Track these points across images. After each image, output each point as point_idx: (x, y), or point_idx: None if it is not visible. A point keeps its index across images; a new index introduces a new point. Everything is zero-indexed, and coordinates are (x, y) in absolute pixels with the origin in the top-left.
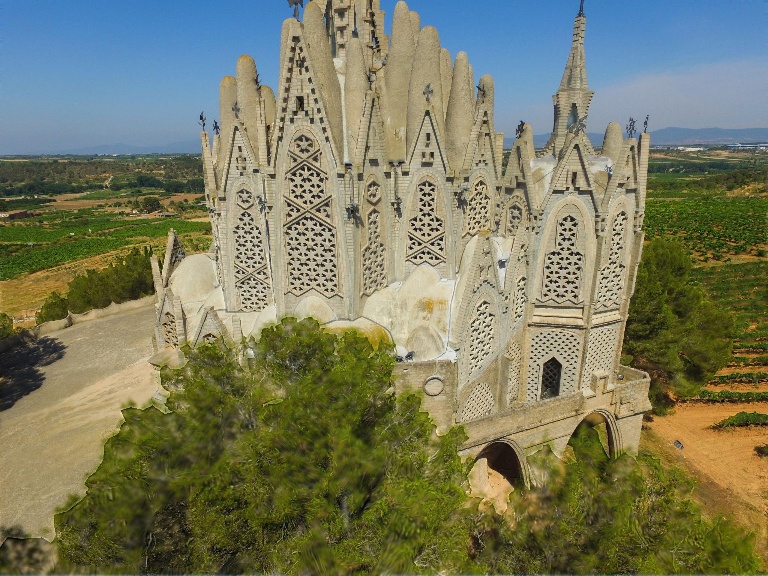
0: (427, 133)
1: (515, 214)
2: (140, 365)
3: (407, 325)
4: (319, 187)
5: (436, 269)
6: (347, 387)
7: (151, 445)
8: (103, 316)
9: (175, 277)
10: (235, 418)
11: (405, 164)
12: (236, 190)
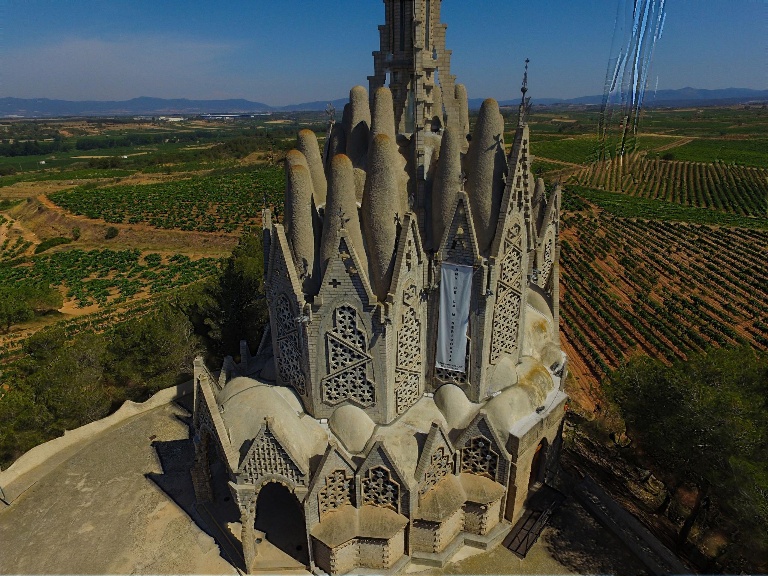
0: None
1: None
2: None
3: (535, 347)
4: (516, 264)
5: None
6: None
7: None
8: None
9: (282, 430)
10: None
11: None
12: (403, 288)
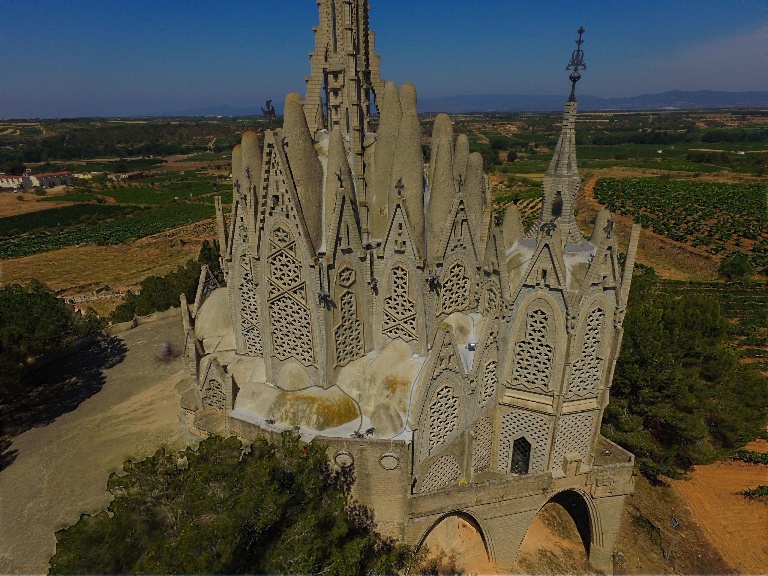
0: (399, 223)
1: (491, 297)
2: (179, 377)
3: (374, 399)
4: (295, 273)
5: (409, 345)
6: (216, 539)
7: (63, 573)
8: (163, 318)
9: (201, 312)
10: (161, 523)
11: (379, 249)
12: (240, 254)
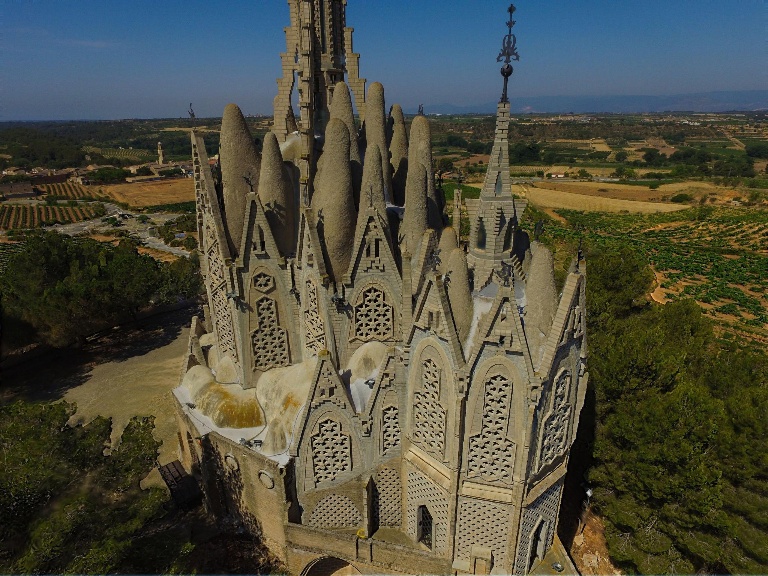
0: None
1: None
2: None
3: None
4: None
5: None
6: None
7: None
8: None
9: None
10: None
11: (296, 259)
12: None
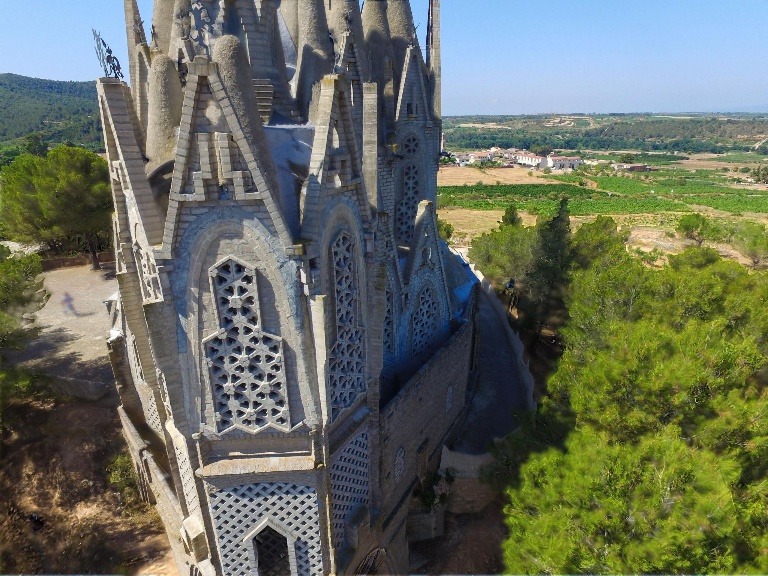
0: None
1: None
2: None
3: None
4: None
5: None
6: None
7: None
8: None
9: None
10: None
11: None
12: None
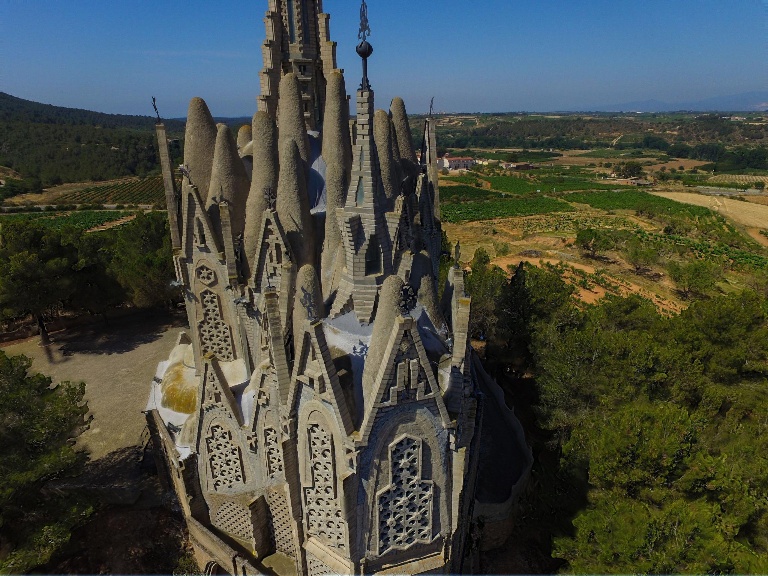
0: None
1: None
2: None
3: None
4: None
5: None
6: None
7: None
8: None
9: None
10: None
11: None
12: None
